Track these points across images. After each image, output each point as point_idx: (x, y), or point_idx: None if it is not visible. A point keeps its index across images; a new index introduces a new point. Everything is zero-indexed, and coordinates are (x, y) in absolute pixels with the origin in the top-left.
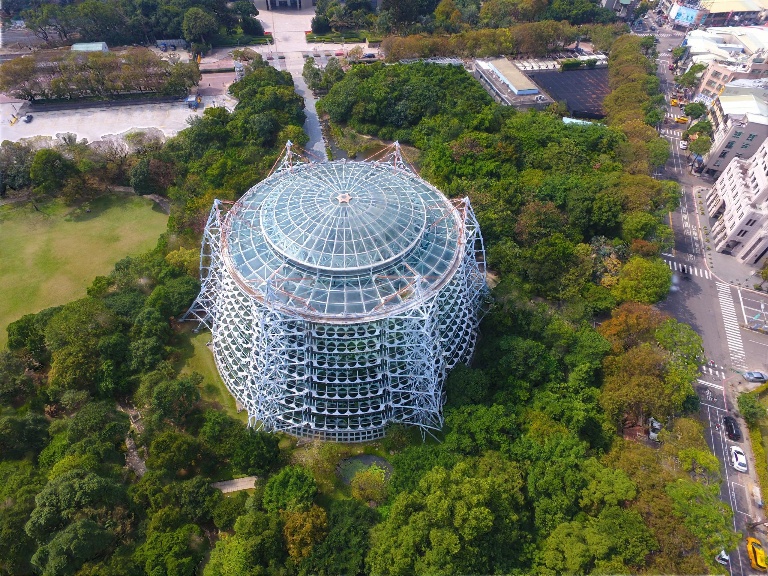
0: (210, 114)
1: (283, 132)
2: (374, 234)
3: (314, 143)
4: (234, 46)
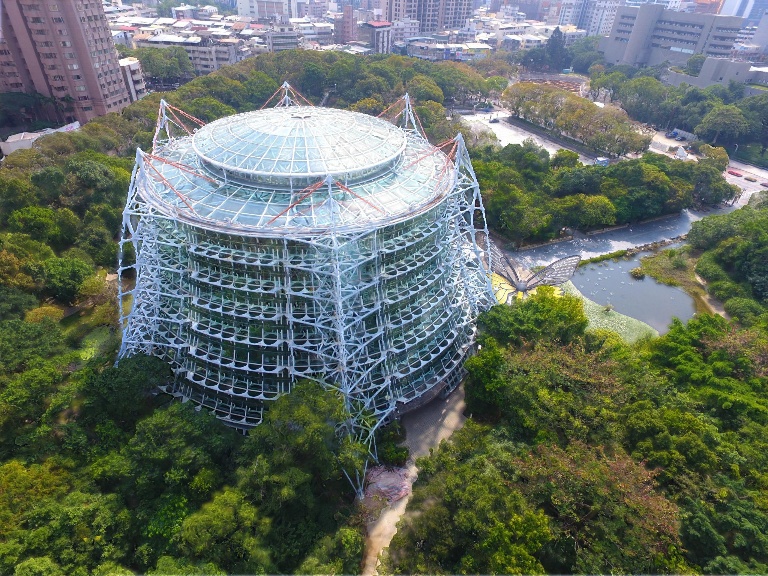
0: (560, 153)
1: (586, 196)
2: (242, 138)
3: (625, 240)
4: (748, 163)
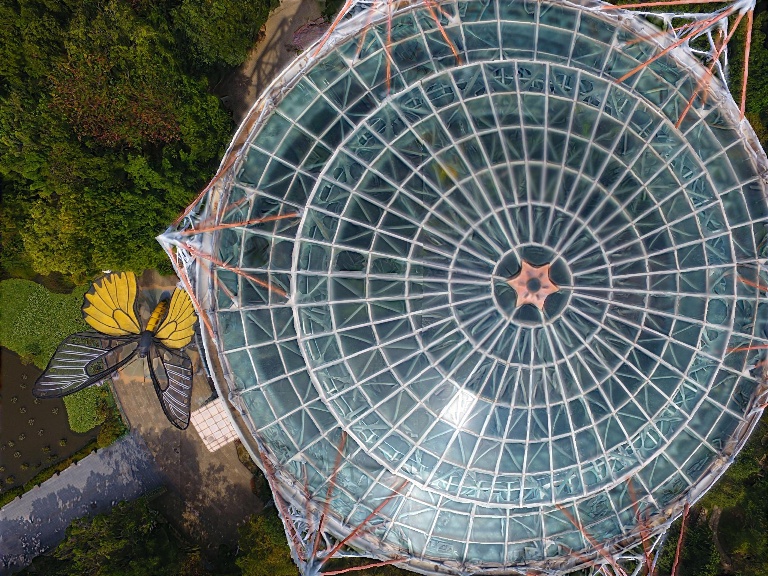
0: None
1: None
2: (616, 163)
3: None
4: None
